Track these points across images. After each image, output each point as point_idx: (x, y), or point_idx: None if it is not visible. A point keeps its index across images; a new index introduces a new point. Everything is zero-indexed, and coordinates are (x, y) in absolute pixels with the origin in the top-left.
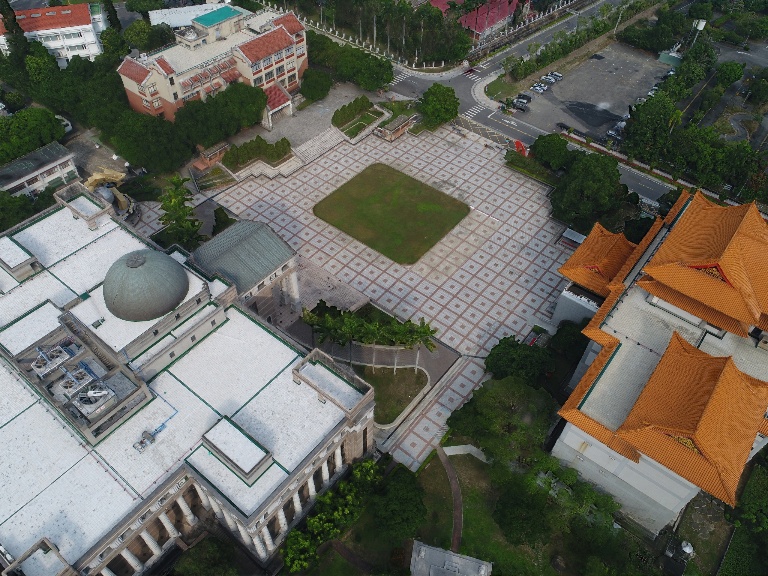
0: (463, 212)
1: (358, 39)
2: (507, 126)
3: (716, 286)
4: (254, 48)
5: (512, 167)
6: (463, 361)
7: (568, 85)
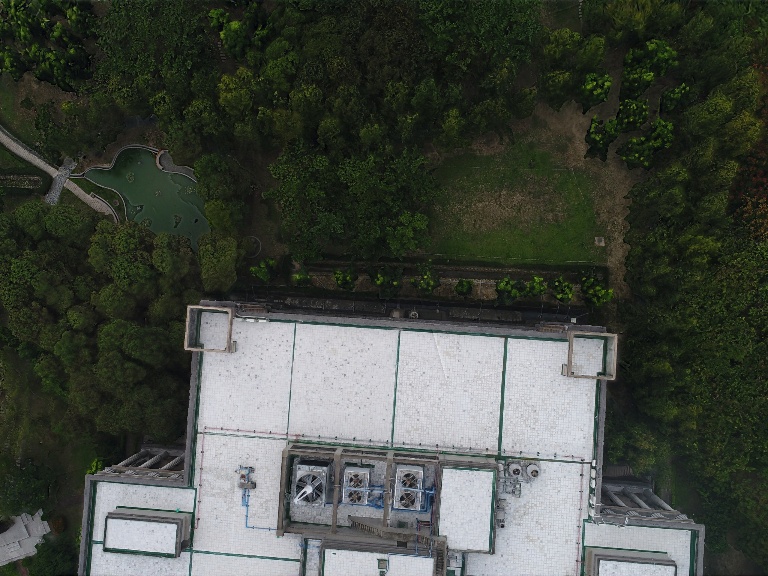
0: None
1: None
2: None
3: None
4: None
5: None
6: None
7: None
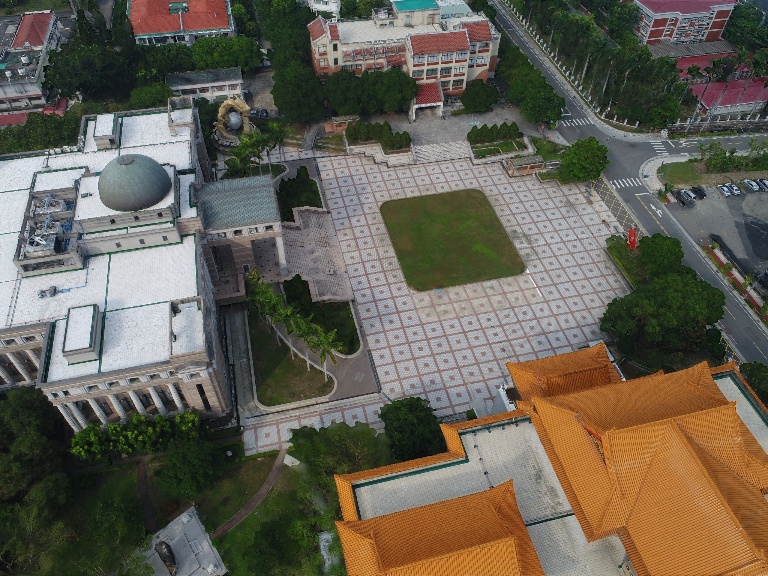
0: (514, 271)
1: (570, 71)
2: (648, 212)
3: (593, 463)
4: (425, 42)
5: (611, 254)
6: (377, 397)
7: None
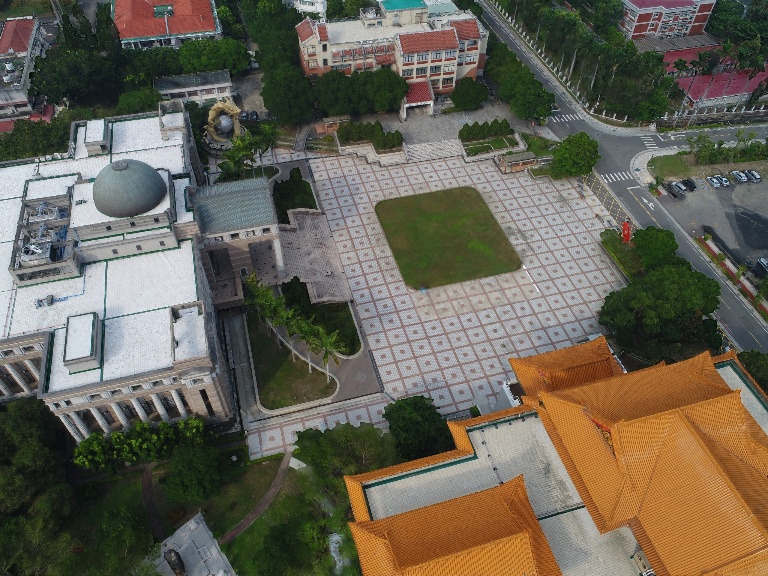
0: (510, 267)
1: (557, 67)
2: (641, 205)
3: (603, 456)
4: (414, 41)
5: (605, 247)
6: (380, 397)
7: (761, 191)
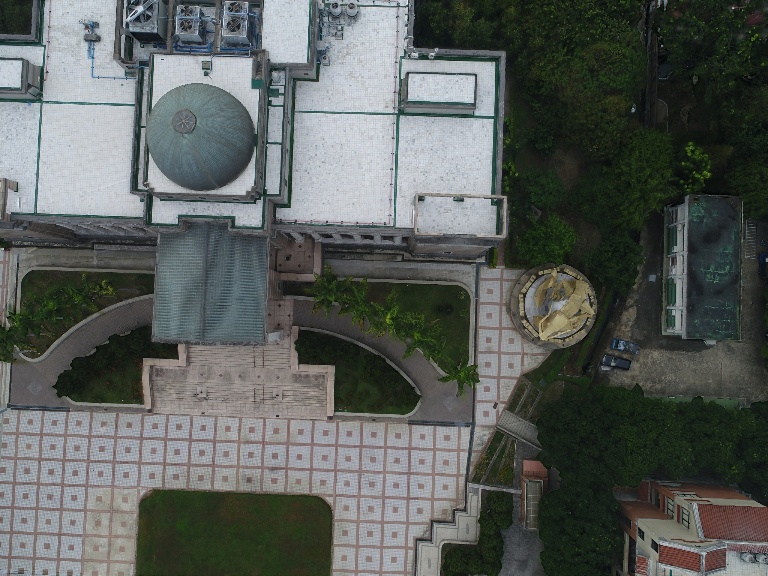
0: None
1: None
2: None
3: None
4: None
5: None
6: (2, 401)
7: None
